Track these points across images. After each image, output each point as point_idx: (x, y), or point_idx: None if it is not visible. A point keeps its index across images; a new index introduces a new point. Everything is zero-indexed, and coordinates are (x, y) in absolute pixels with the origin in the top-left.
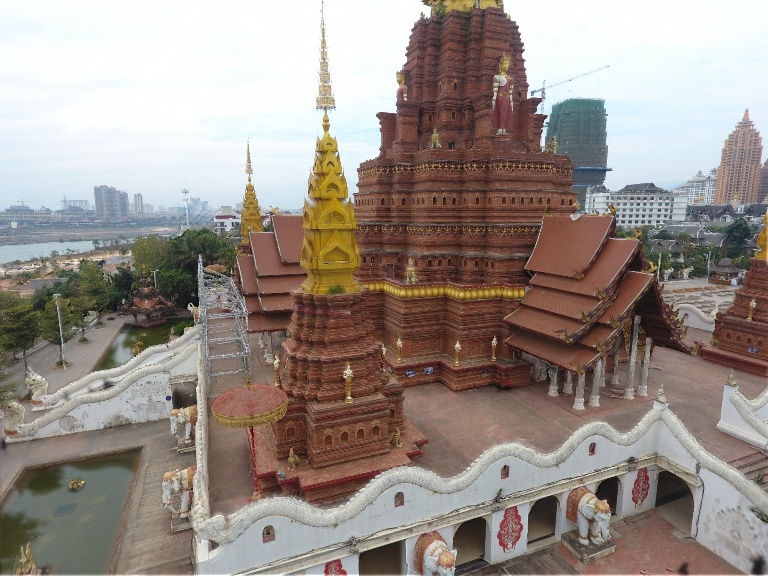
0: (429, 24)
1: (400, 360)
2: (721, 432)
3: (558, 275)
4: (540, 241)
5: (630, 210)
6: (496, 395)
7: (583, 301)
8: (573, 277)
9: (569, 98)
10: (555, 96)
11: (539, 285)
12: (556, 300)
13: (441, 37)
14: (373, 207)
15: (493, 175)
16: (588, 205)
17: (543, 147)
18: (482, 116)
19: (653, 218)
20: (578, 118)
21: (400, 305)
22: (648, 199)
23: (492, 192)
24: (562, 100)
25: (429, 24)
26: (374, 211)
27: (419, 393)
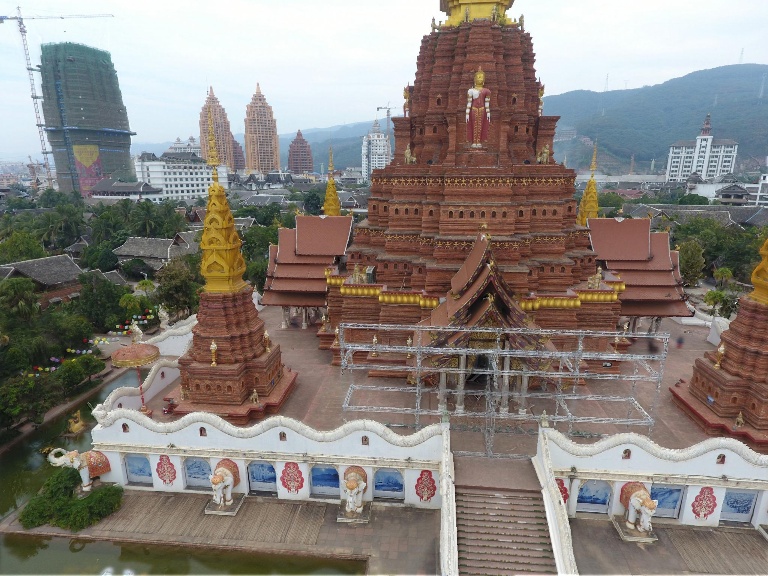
0: (495, 29)
1: (616, 352)
2: (685, 325)
3: (633, 260)
4: (594, 237)
5: (186, 179)
6: (634, 351)
7: (661, 274)
8: (647, 260)
9: (68, 41)
10: (43, 33)
11: (620, 269)
12: (641, 277)
13: (508, 48)
14: (509, 220)
15: (570, 188)
16: (141, 174)
17: (39, 97)
18: (550, 136)
19: (205, 187)
20: (87, 69)
21: (607, 308)
22: (198, 168)
23: (573, 202)
24: (56, 41)
25: (495, 29)
26: (511, 224)
27: (630, 371)
